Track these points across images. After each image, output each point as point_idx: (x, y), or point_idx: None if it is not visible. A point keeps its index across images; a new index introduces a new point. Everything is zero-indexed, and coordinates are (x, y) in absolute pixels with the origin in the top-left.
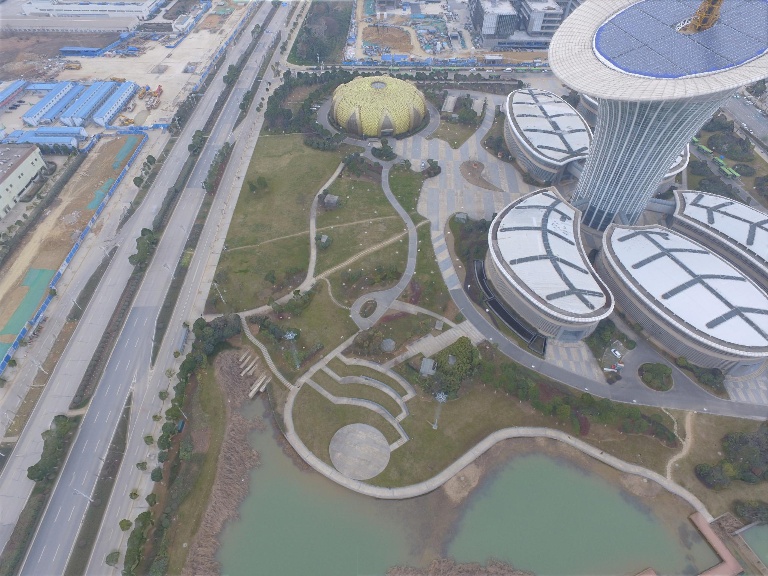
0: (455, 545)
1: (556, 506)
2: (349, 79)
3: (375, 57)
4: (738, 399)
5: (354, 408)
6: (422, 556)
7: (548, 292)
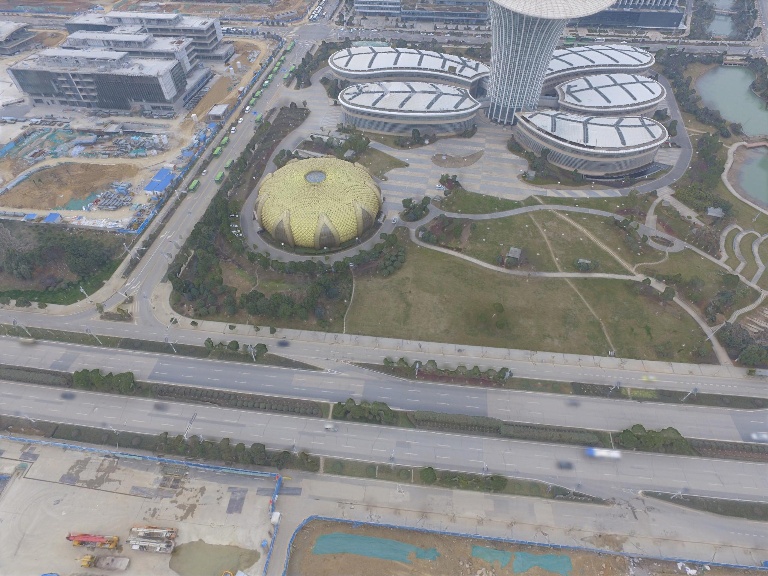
0: None
1: None
2: (227, 220)
3: (136, 200)
4: (669, 113)
5: (763, 258)
6: None
7: (649, 136)
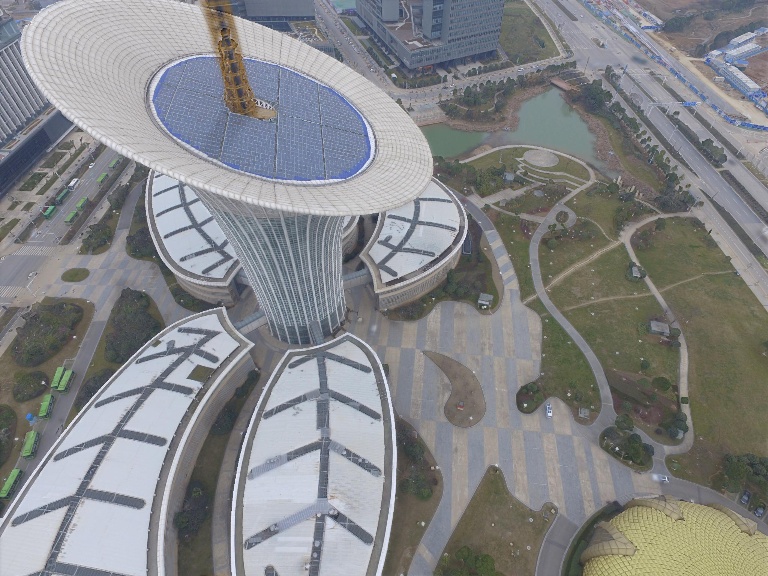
0: (487, 135)
1: (436, 145)
2: None
3: None
4: None
5: (551, 171)
6: (501, 133)
7: None
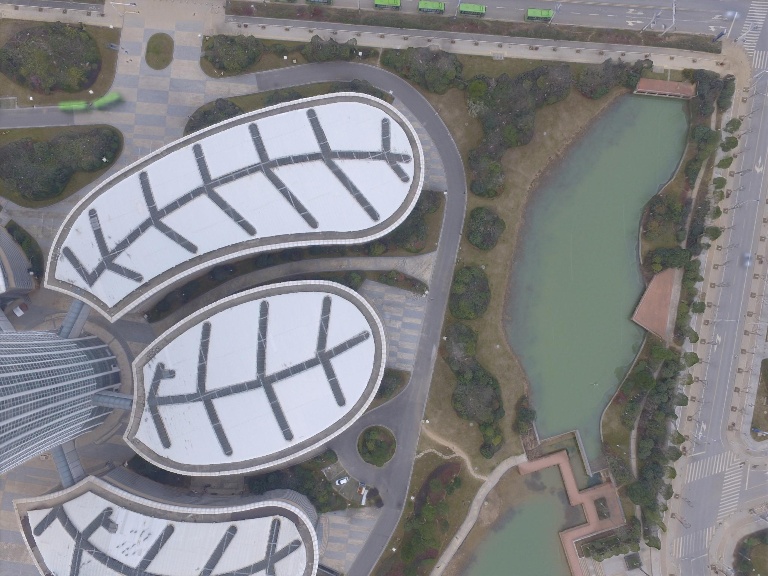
0: None
1: None
2: None
3: None
4: (411, 364)
5: None
6: None
7: None
